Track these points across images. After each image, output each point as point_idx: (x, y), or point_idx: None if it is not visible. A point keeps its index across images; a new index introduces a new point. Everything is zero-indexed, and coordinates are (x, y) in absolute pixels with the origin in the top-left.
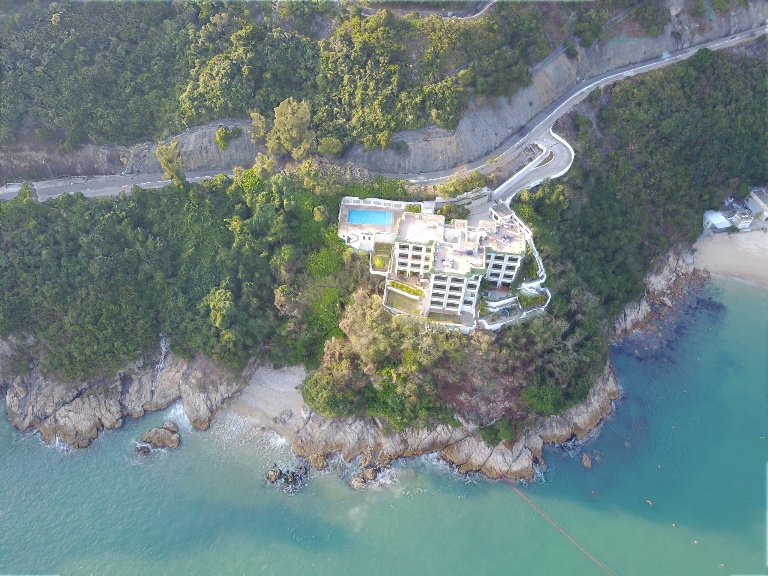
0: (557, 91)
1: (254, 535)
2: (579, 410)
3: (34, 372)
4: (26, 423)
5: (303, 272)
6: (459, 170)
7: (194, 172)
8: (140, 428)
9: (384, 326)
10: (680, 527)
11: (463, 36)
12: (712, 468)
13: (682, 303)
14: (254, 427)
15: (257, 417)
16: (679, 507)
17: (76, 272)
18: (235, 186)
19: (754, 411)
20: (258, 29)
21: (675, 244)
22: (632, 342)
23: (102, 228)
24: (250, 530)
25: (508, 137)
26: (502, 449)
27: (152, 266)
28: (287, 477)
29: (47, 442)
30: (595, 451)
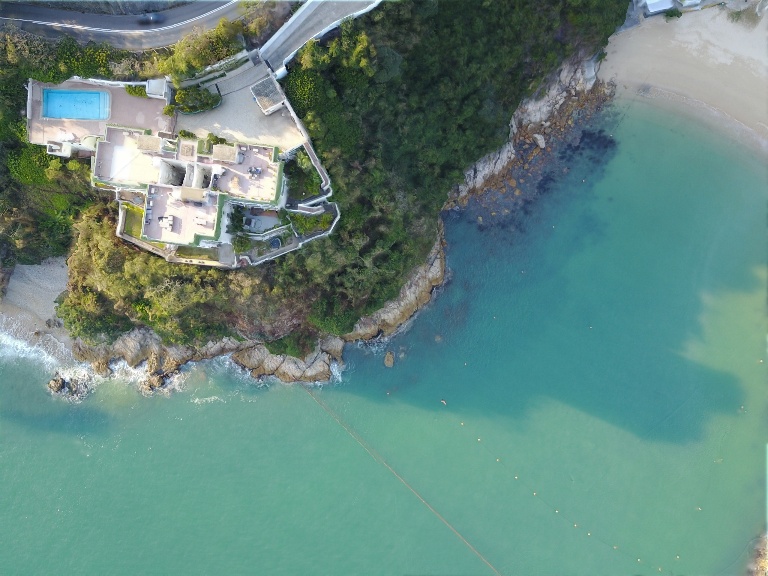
0: None
1: (46, 442)
2: (388, 308)
3: None
4: None
5: None
6: None
7: None
8: None
9: (115, 276)
10: (468, 427)
11: None
12: (522, 363)
13: (561, 140)
14: (28, 330)
15: (29, 319)
16: (474, 405)
17: None
18: None
19: (594, 294)
20: None
21: (573, 53)
22: (479, 204)
23: None
24: (42, 437)
25: None
26: (294, 359)
27: None
28: (70, 386)
29: None
30: (401, 348)
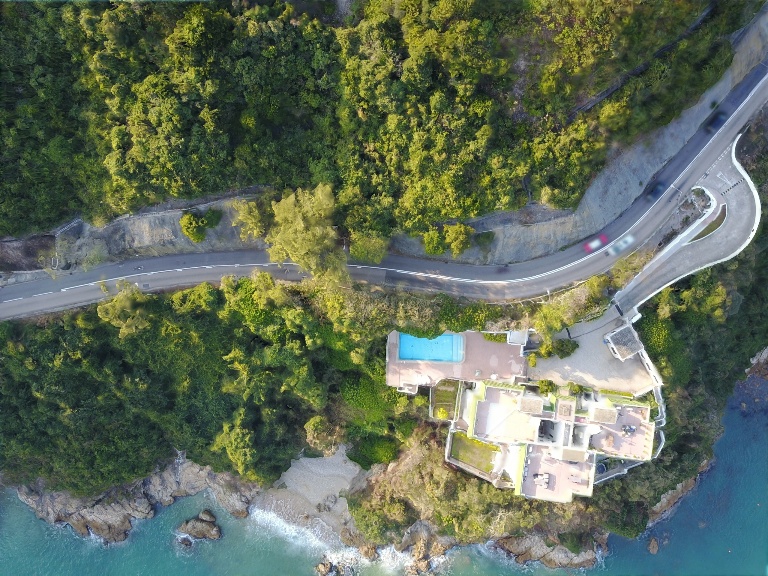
0: (767, 51)
1: None
2: None
3: (39, 481)
4: (51, 521)
5: (339, 391)
6: (573, 290)
7: (160, 259)
8: (174, 514)
9: (448, 503)
10: None
11: (626, 30)
12: None
13: None
14: (297, 514)
15: (298, 502)
16: None
17: (44, 422)
18: (229, 311)
19: None
20: (215, 22)
21: None
22: (742, 390)
23: (56, 376)
24: None
25: (658, 171)
26: (566, 550)
27: (140, 407)
28: (338, 570)
29: (81, 536)
30: (665, 534)
